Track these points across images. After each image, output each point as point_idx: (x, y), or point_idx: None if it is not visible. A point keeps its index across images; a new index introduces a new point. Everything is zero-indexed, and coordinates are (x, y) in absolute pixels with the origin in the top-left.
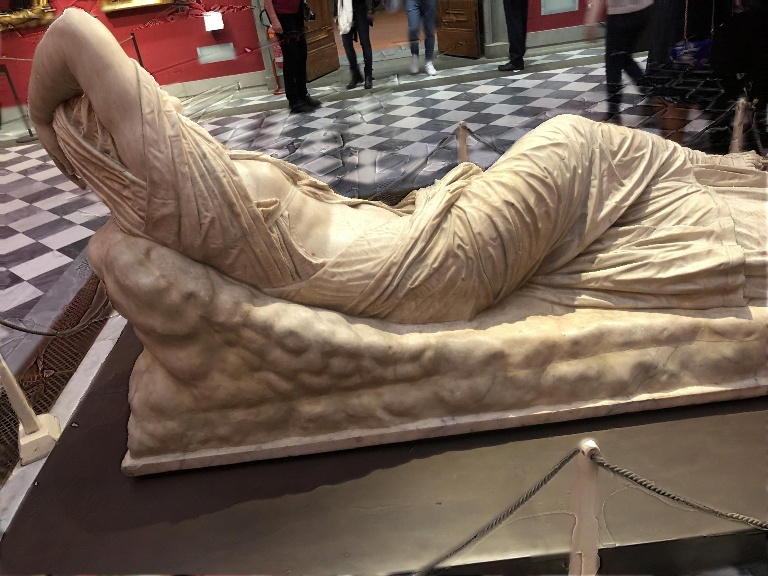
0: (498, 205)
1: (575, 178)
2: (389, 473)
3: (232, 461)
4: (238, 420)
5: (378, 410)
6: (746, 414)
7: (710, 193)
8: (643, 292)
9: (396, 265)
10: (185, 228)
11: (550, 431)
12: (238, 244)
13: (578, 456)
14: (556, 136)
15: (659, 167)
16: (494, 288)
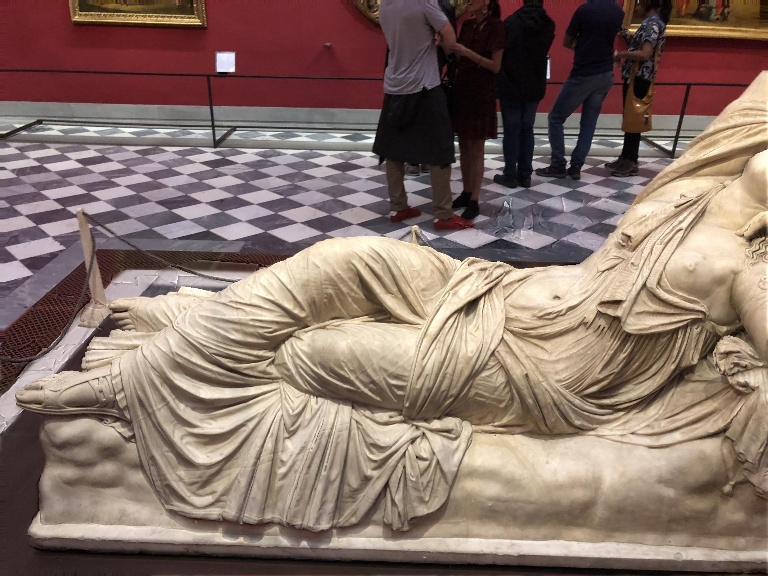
0: None
1: None
2: None
3: None
4: None
5: None
6: None
7: None
8: None
9: None
10: None
11: None
12: None
13: None
14: None
15: None
16: None
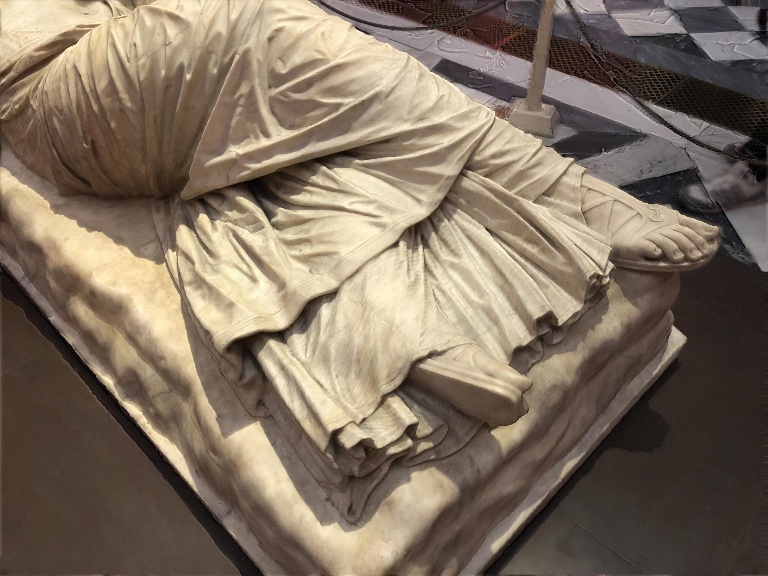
0: (67, 67)
1: (182, 83)
2: None
3: None
4: None
5: None
6: (205, 534)
7: (383, 231)
8: None
9: None
10: None
11: None
12: None
13: None
14: (188, 3)
15: (366, 142)
16: (81, 174)
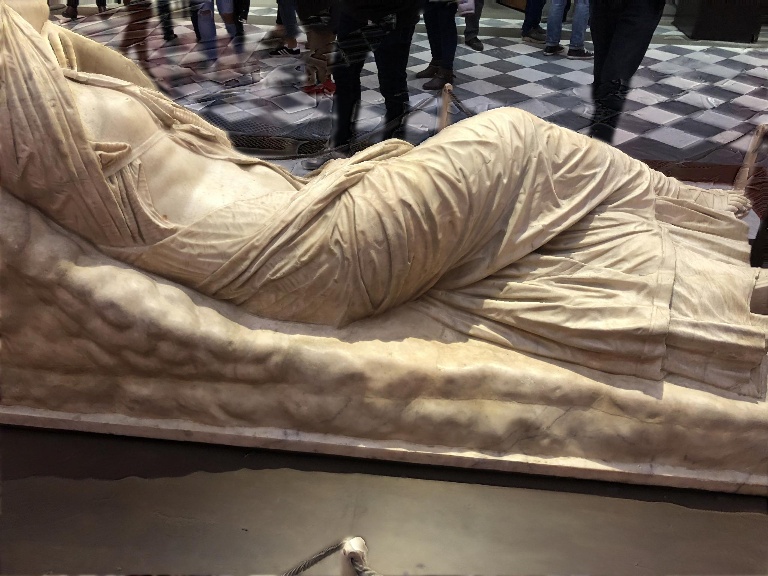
0: (392, 203)
1: (498, 188)
2: (211, 478)
3: (48, 425)
4: (54, 384)
5: (213, 406)
6: (630, 502)
7: (662, 236)
8: (547, 338)
9: (257, 249)
10: (1, 158)
11: (405, 470)
12: (65, 189)
13: (339, 553)
14: (487, 132)
15: (612, 192)
16: (374, 297)
